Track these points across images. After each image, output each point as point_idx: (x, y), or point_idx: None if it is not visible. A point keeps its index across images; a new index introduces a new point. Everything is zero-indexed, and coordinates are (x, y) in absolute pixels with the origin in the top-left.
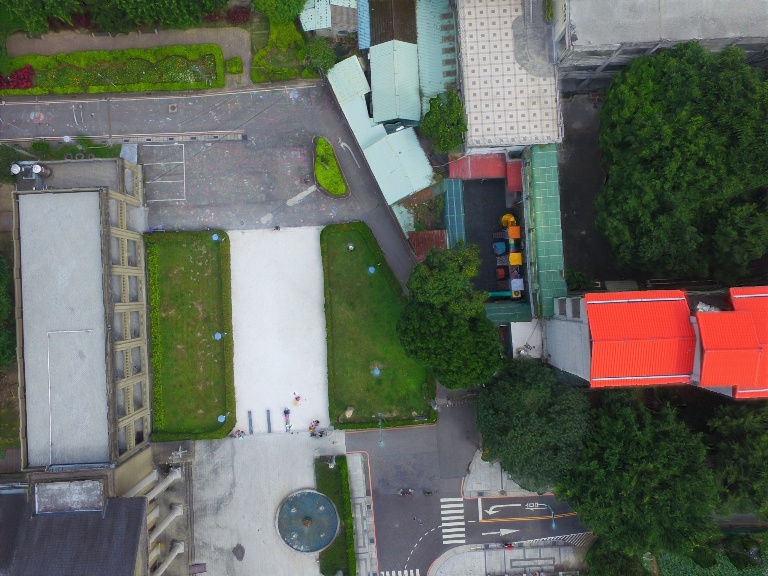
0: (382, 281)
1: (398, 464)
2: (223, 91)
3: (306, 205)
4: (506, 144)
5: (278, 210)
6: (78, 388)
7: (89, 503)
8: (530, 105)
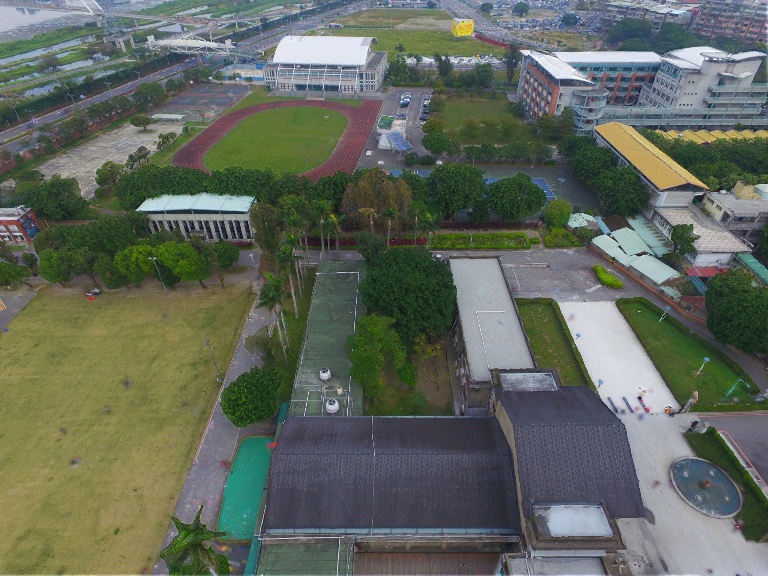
0: (670, 328)
1: (761, 442)
2: (529, 250)
3: (599, 292)
4: (721, 251)
5: (581, 294)
6: (502, 339)
7: (543, 389)
8: (722, 240)
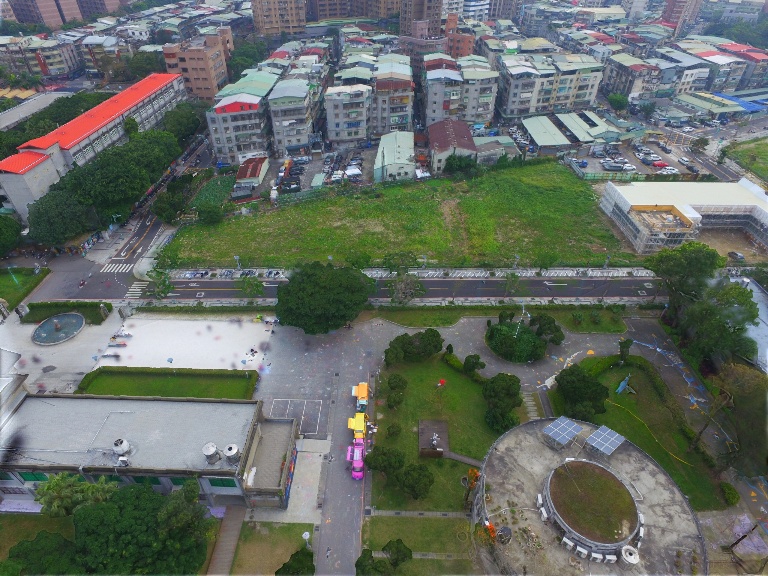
0: None
1: None
2: None
3: None
4: None
5: None
6: None
7: None
8: None
